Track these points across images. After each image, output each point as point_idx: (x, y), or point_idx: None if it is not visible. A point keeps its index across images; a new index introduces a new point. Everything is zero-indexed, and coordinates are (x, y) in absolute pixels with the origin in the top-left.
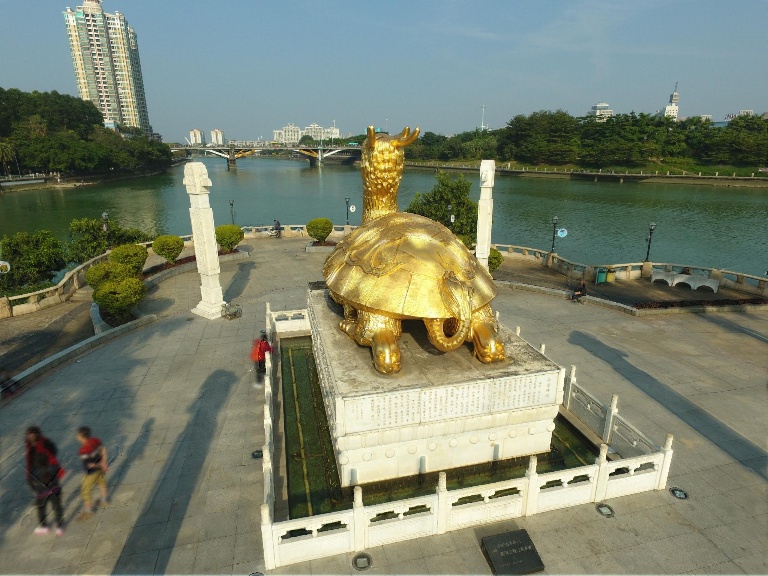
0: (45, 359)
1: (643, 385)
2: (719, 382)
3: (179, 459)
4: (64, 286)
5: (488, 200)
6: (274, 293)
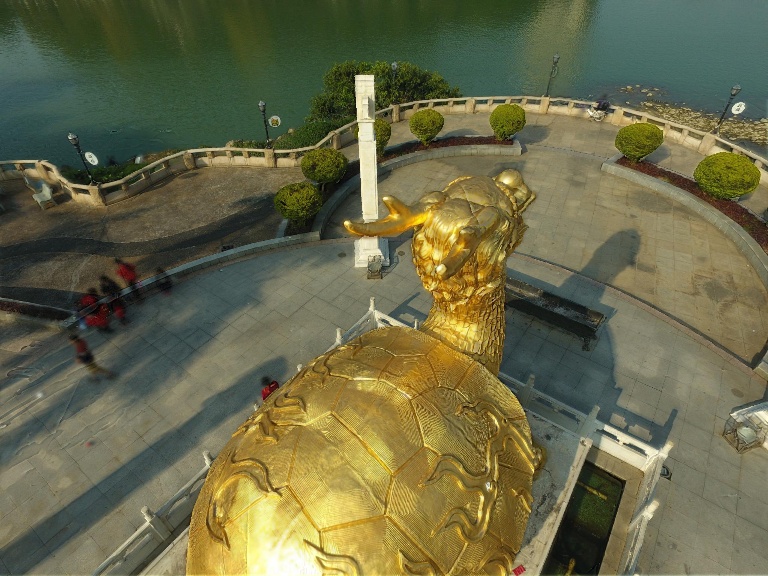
0: (201, 258)
1: None
2: None
3: (125, 470)
4: (322, 146)
5: None
6: None
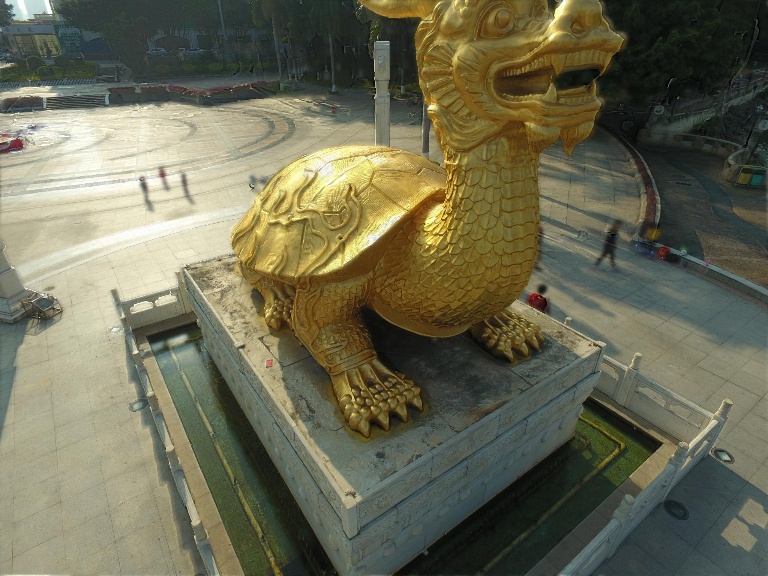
0: None
1: None
2: None
3: None
4: None
5: None
6: None
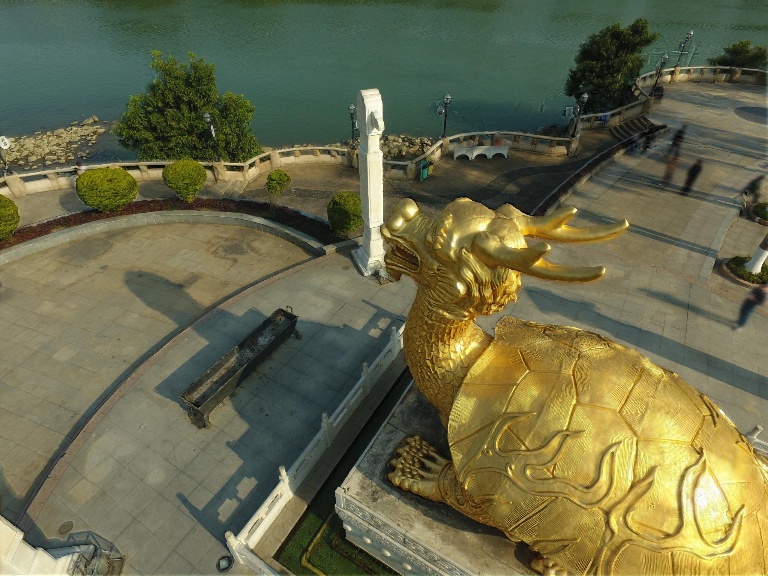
0: None
1: (654, 348)
2: (673, 307)
3: None
4: None
5: (380, 152)
6: (97, 437)
